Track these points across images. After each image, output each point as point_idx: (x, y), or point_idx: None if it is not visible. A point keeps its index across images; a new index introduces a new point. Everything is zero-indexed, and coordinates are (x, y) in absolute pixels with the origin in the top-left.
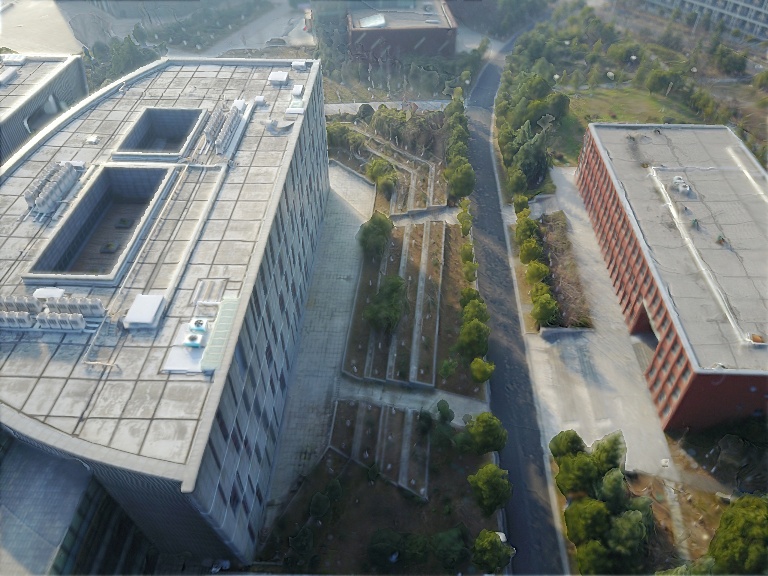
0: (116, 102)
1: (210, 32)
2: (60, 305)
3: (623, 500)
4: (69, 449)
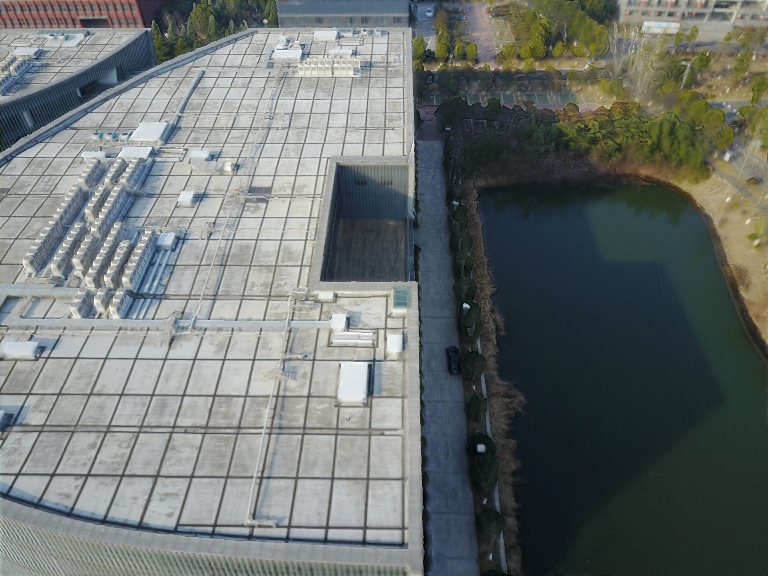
0: None
1: None
2: (5, 66)
3: (180, 36)
4: (115, 52)
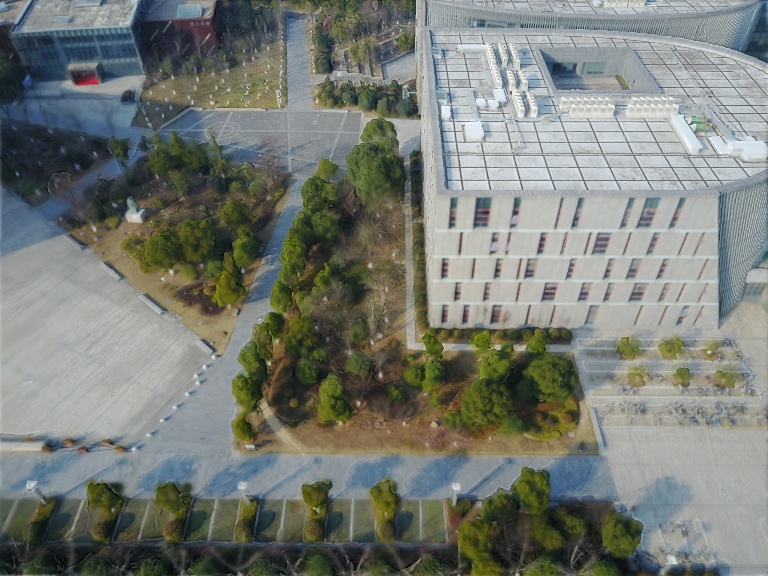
0: (501, 7)
1: (62, 143)
2: None
3: None
4: None
